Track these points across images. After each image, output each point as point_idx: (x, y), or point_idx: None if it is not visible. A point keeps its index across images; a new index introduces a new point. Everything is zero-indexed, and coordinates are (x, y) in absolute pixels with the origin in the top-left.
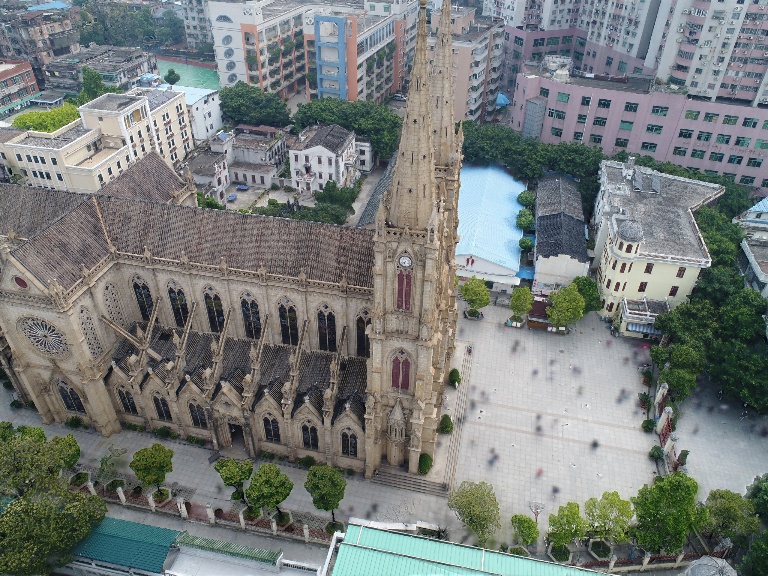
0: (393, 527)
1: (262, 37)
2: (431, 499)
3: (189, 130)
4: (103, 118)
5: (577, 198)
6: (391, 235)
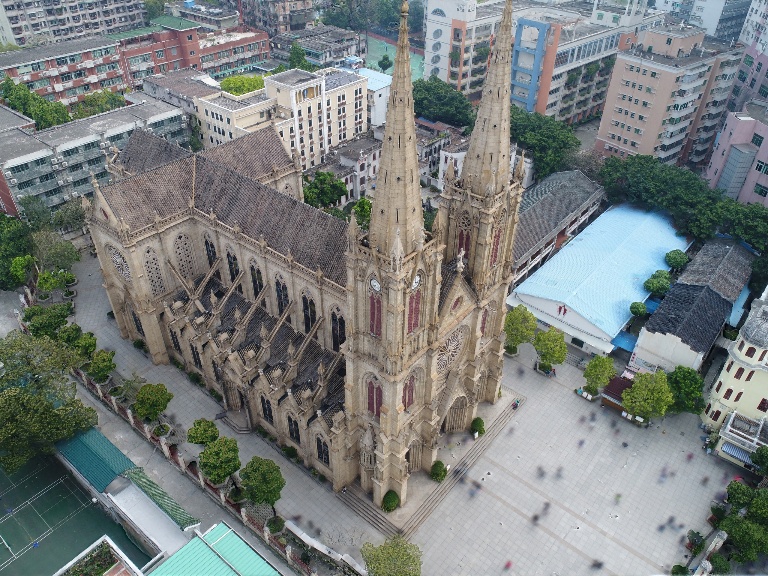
0: (319, 548)
1: (471, 35)
2: (381, 539)
3: (365, 114)
4: (280, 90)
5: (743, 274)
6: (362, 253)
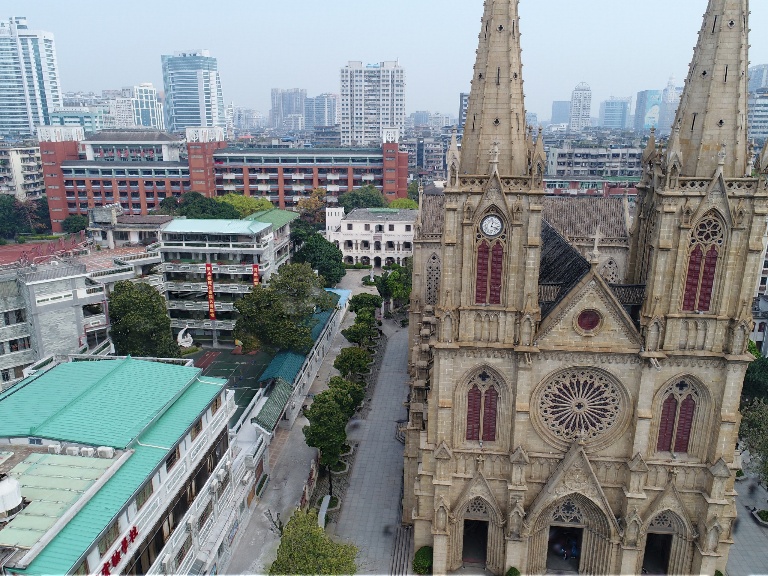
0: None
1: None
2: None
3: None
4: None
5: None
6: None
